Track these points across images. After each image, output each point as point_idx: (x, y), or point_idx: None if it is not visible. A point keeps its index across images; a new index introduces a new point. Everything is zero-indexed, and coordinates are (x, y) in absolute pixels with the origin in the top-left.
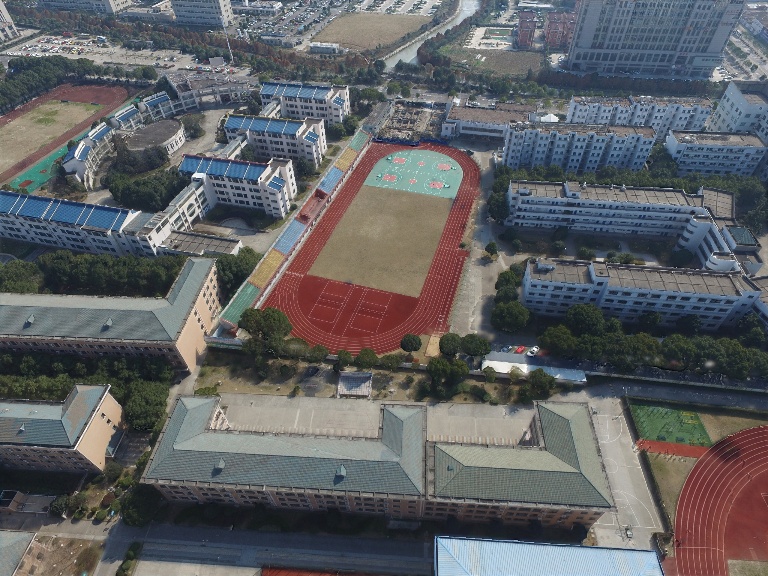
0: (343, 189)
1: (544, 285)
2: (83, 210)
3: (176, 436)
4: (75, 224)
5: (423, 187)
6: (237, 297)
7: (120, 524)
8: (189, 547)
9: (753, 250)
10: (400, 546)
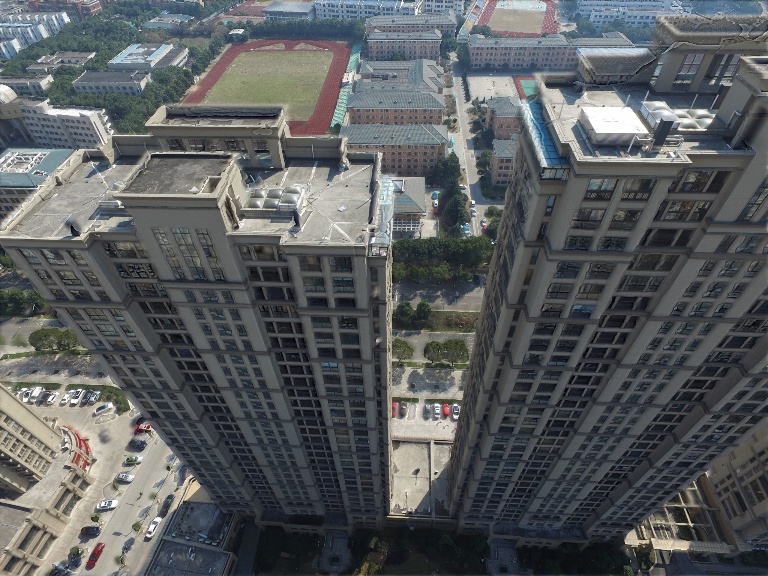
0: (486, 9)
1: (600, 15)
2: (378, 0)
3: None
4: (377, 6)
5: (527, 8)
6: (462, 30)
7: (454, 72)
8: None
9: (689, 5)
10: None
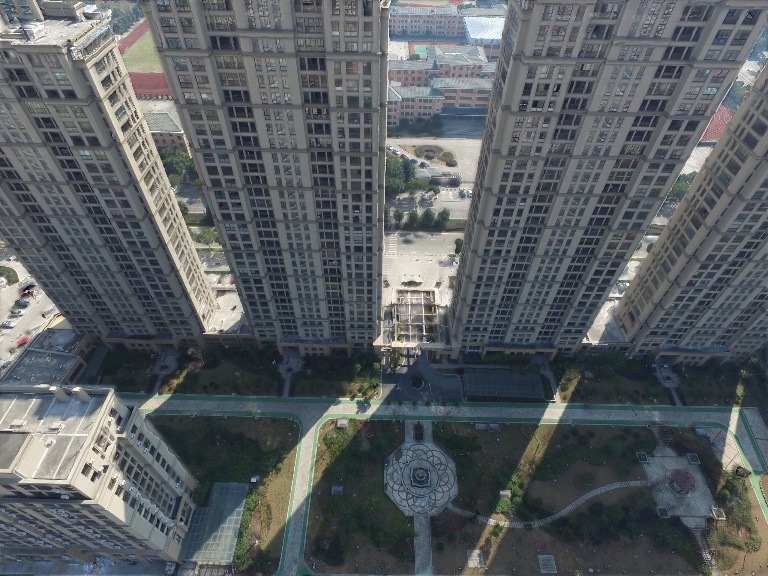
0: None
1: None
2: None
3: None
4: None
5: None
6: None
7: None
8: None
9: None
10: (450, 39)
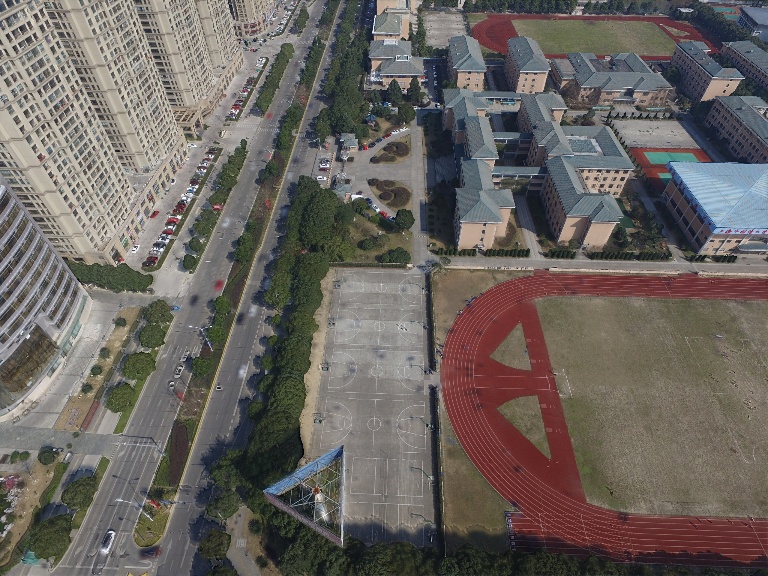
0: None
1: None
2: None
3: (743, 96)
4: None
5: None
6: None
7: (684, 114)
8: (692, 131)
9: None
10: None
